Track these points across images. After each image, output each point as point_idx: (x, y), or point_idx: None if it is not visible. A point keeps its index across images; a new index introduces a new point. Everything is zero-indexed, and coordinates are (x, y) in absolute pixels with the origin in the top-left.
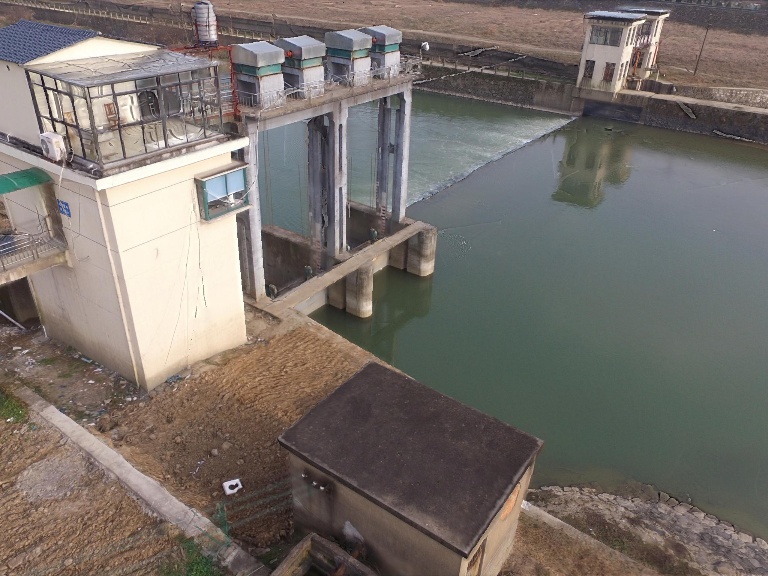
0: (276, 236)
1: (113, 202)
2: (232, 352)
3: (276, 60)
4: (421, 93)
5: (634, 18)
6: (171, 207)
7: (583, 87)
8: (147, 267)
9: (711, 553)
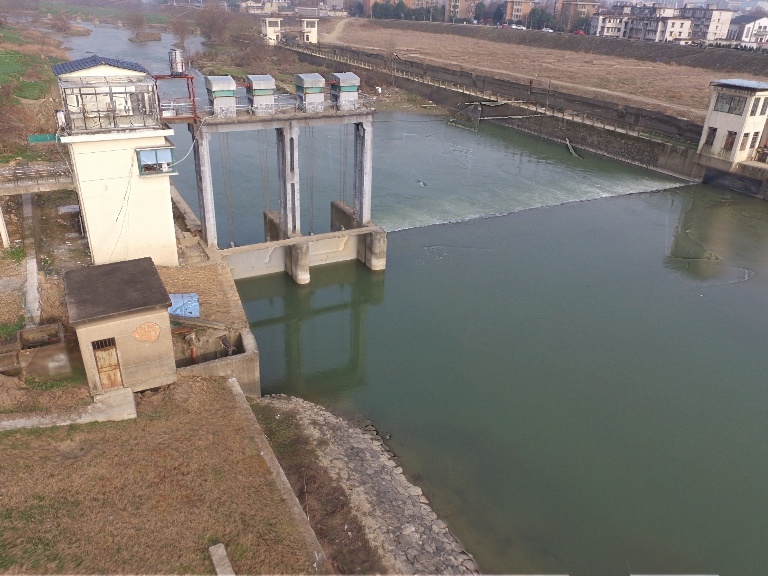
0: (268, 217)
1: (77, 152)
2: (162, 267)
3: (229, 88)
4: (561, 146)
5: (758, 88)
6: (118, 163)
7: (703, 153)
8: (99, 195)
9: (343, 454)
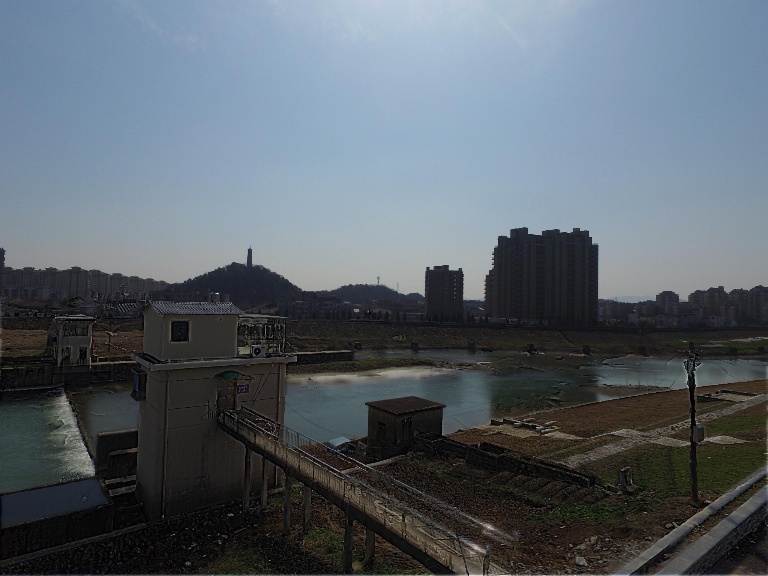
0: (134, 452)
1: None
2: None
3: None
4: None
5: None
6: None
7: (63, 366)
8: None
9: None
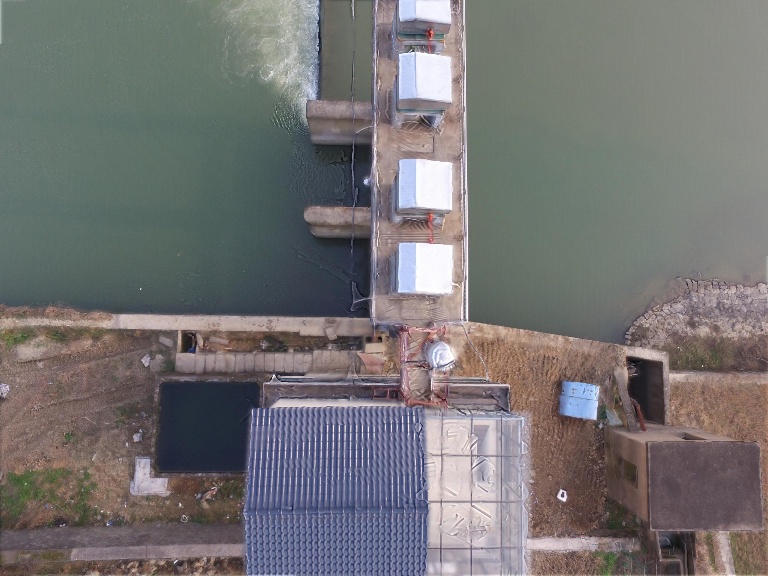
0: None
1: None
2: None
3: None
4: None
5: None
6: None
7: None
8: None
9: (729, 320)
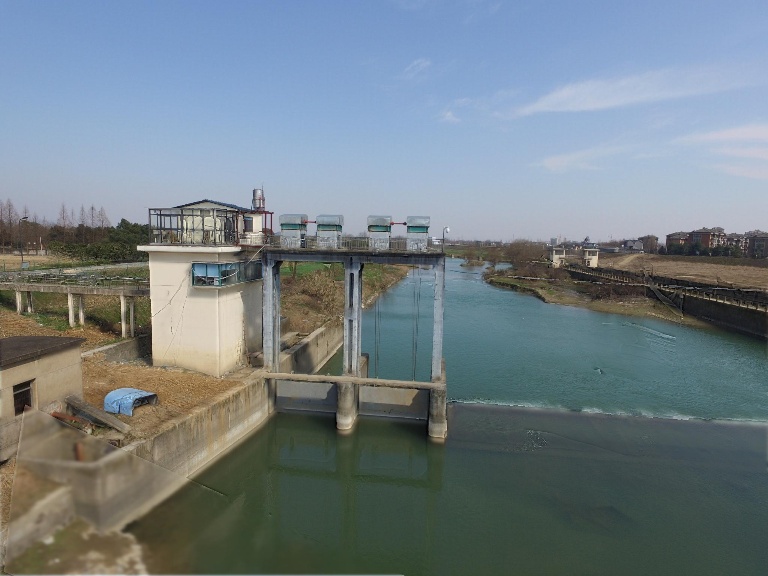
0: None
1: (152, 260)
2: (202, 374)
3: (294, 222)
4: None
5: None
6: (180, 273)
7: None
8: (163, 298)
9: None
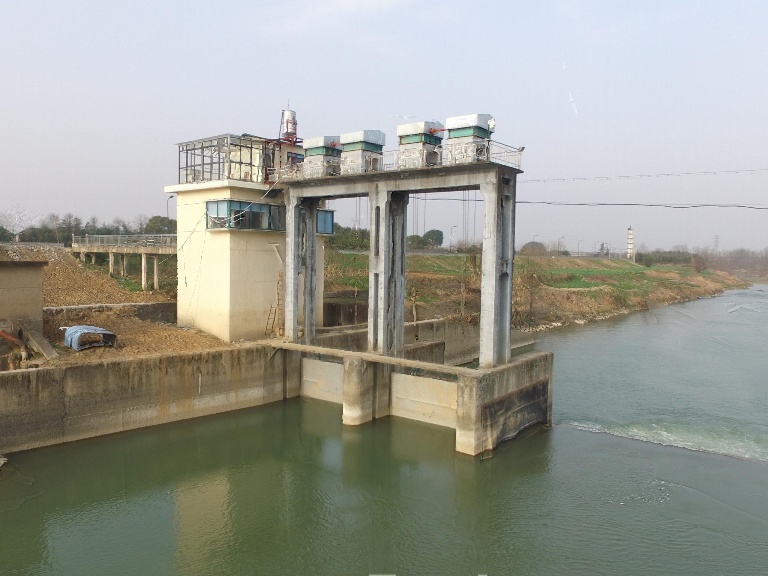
0: None
1: None
2: (214, 337)
3: None
4: None
5: None
6: None
7: None
8: None
9: None
